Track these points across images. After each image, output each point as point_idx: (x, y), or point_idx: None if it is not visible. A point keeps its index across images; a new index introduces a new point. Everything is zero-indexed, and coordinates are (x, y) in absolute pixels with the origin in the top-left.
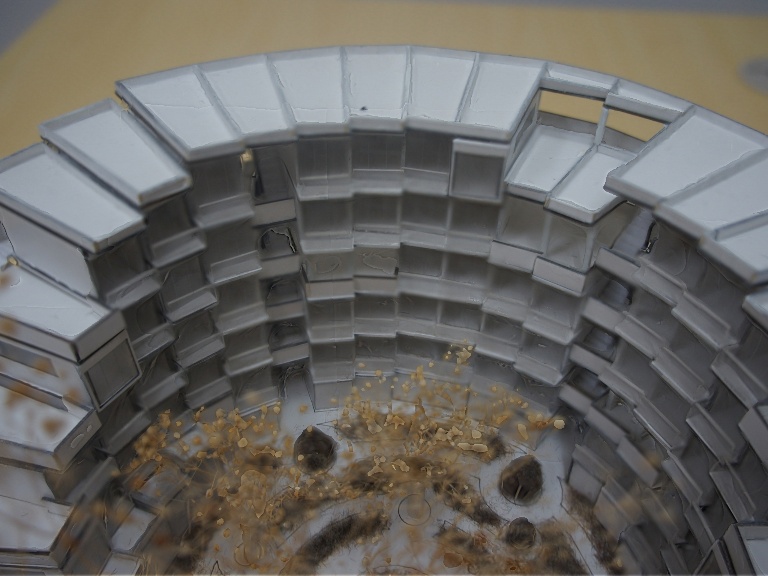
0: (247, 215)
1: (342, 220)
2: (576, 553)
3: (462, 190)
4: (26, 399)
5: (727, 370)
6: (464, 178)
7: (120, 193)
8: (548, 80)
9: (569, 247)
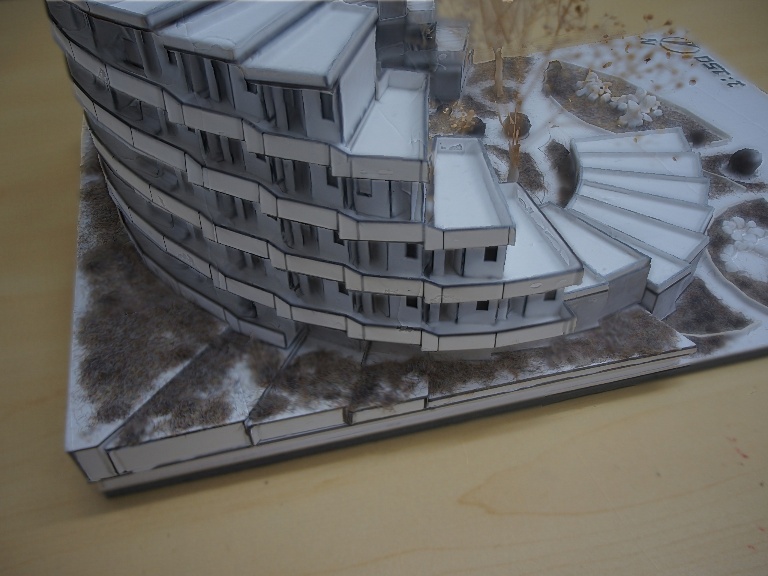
0: None
1: None
2: None
3: None
4: (436, 194)
5: None
6: None
7: (315, 7)
8: None
9: None
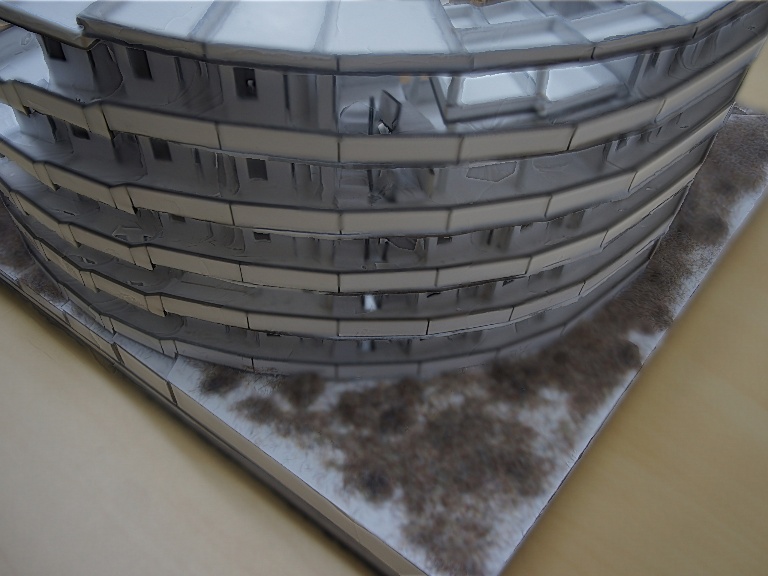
0: None
1: None
2: None
3: None
4: None
5: None
6: None
7: None
8: (639, 2)
9: None
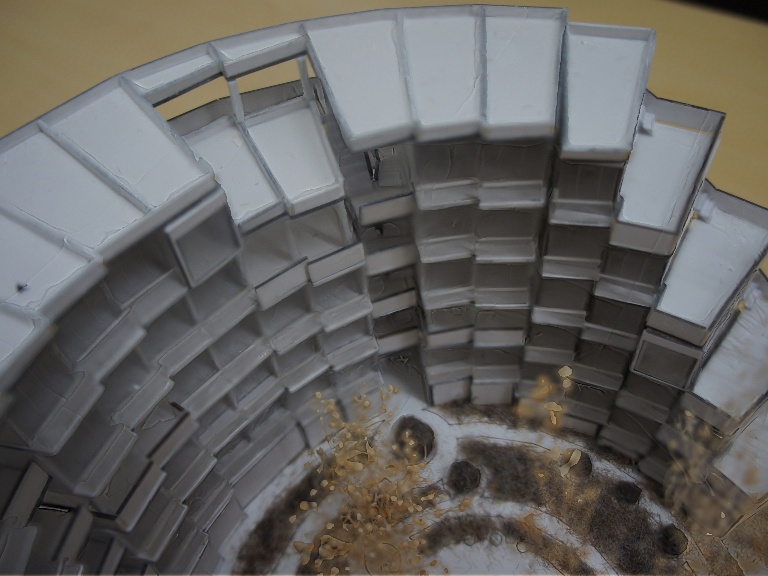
0: (31, 540)
1: (95, 422)
2: (499, 442)
3: (200, 271)
4: None
5: (561, 214)
6: (198, 257)
7: None
8: (152, 94)
9: (299, 232)
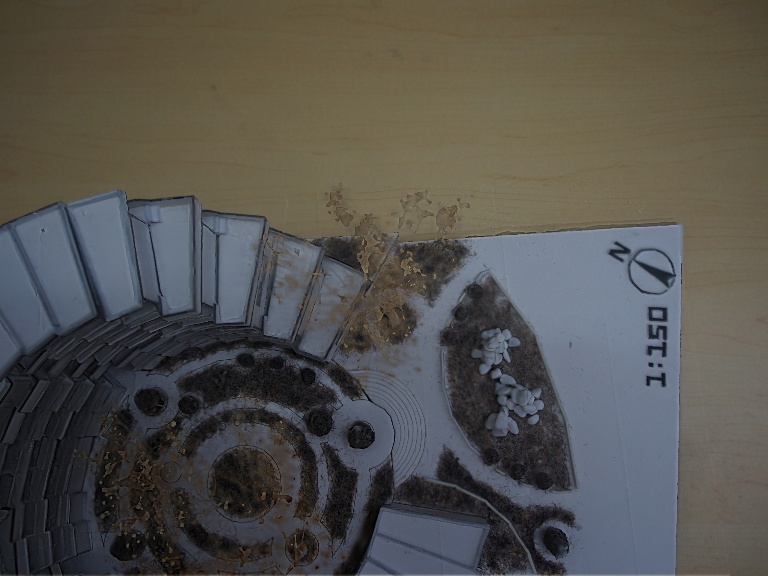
0: None
1: None
2: (199, 371)
3: None
4: None
5: None
6: None
7: None
8: None
9: None
